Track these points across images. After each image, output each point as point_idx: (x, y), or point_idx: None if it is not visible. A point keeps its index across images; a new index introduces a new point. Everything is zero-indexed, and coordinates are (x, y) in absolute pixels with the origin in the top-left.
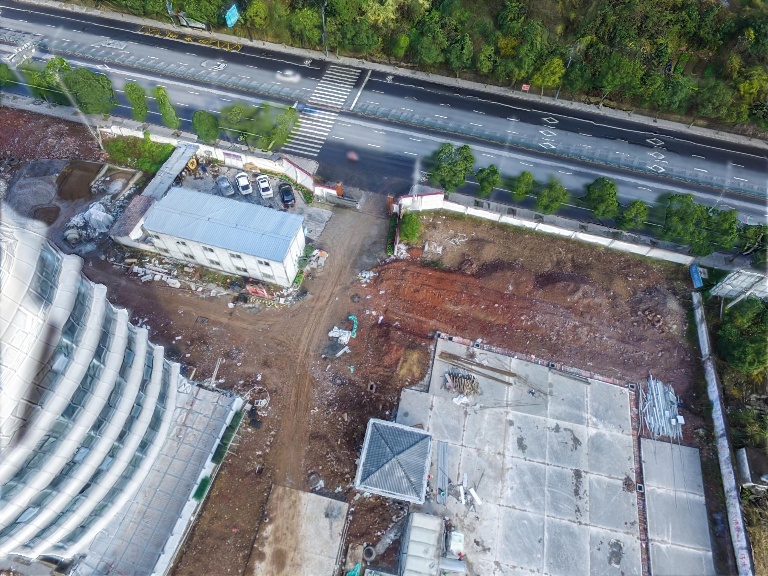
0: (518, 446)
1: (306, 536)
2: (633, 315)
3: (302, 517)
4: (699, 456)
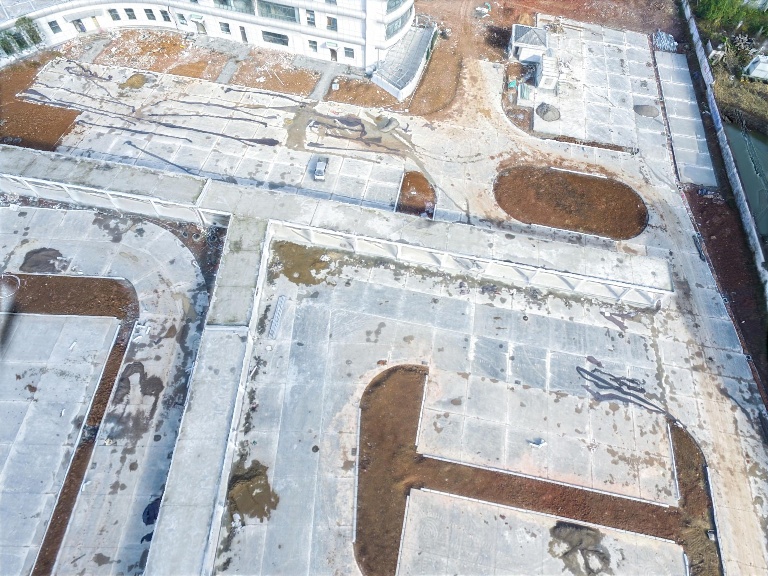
0: (589, 51)
1: (486, 72)
2: (648, 6)
3: (482, 67)
4: (686, 57)
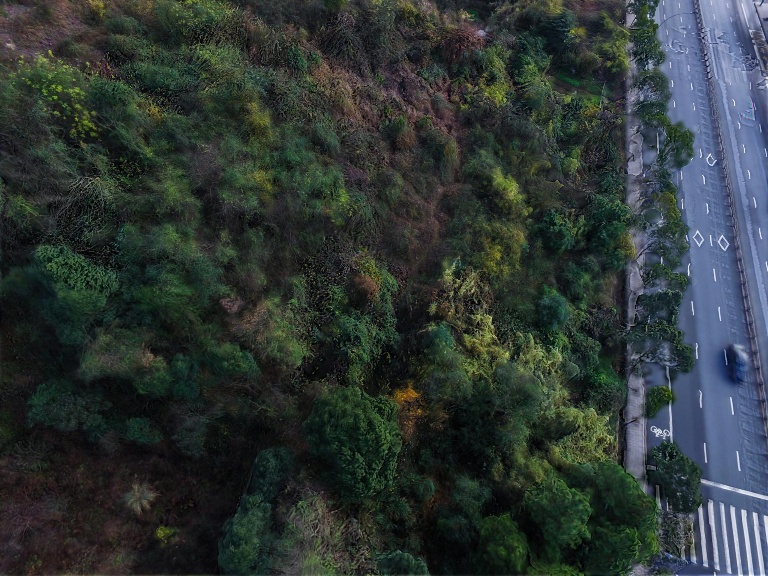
0: None
1: None
2: None
3: None
4: None
